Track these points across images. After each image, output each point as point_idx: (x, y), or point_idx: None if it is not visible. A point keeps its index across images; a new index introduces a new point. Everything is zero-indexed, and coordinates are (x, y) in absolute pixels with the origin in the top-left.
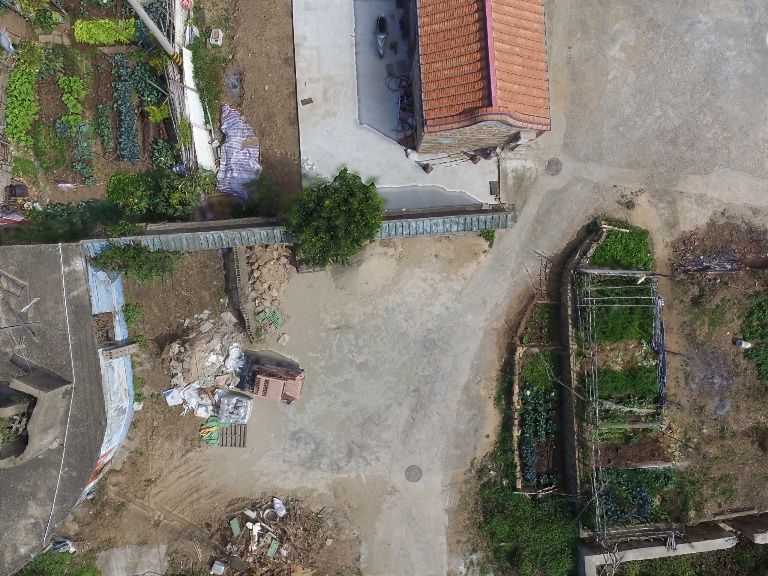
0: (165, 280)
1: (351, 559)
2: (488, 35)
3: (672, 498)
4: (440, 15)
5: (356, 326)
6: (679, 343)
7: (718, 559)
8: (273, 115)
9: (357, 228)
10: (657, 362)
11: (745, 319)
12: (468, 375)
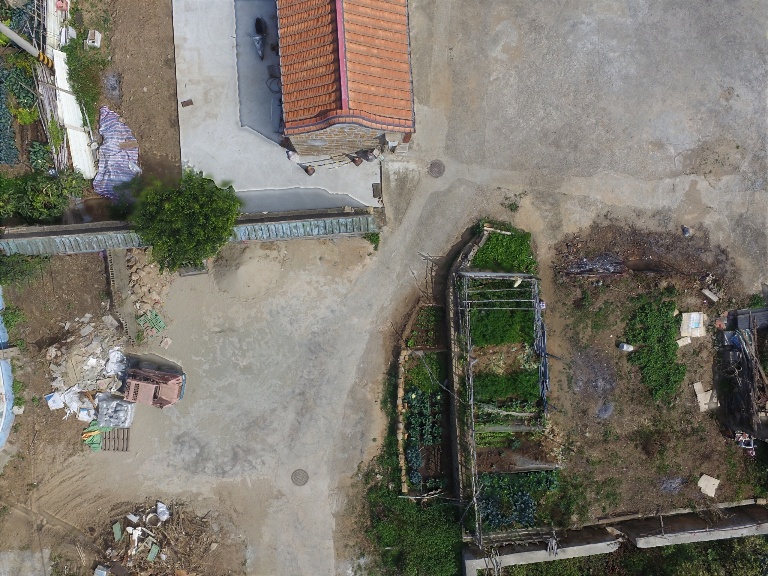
0: (46, 283)
1: (237, 563)
2: (338, 37)
3: (556, 502)
4: (297, 16)
5: (240, 329)
6: (562, 346)
7: (606, 563)
8: (153, 117)
9: (204, 232)
10: (539, 365)
11: (628, 322)
12: (354, 378)
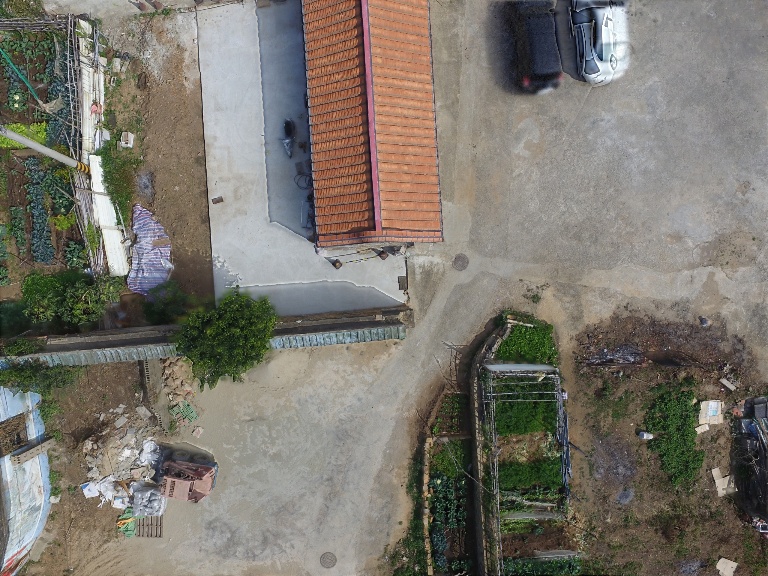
0: (81, 375)
1: None
2: (371, 160)
3: None
4: (330, 134)
5: (269, 418)
6: (584, 435)
7: None
8: (184, 214)
9: (243, 351)
10: (561, 454)
11: (648, 411)
12: (381, 464)
